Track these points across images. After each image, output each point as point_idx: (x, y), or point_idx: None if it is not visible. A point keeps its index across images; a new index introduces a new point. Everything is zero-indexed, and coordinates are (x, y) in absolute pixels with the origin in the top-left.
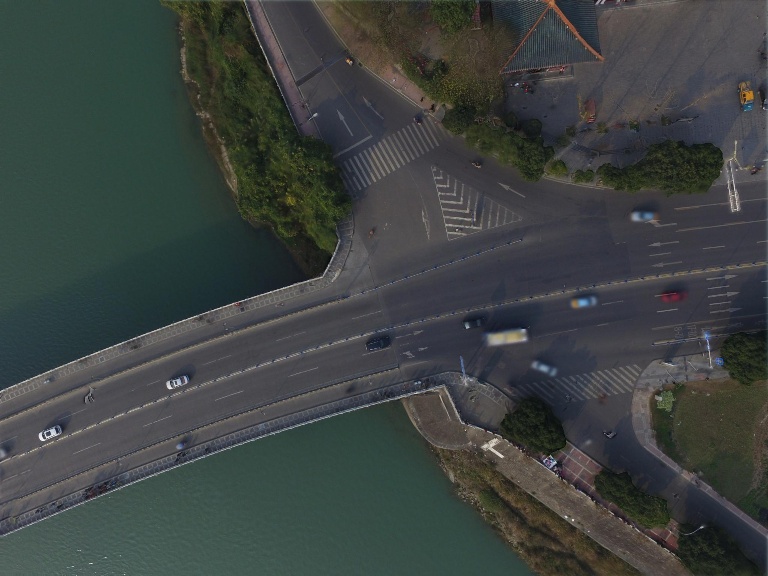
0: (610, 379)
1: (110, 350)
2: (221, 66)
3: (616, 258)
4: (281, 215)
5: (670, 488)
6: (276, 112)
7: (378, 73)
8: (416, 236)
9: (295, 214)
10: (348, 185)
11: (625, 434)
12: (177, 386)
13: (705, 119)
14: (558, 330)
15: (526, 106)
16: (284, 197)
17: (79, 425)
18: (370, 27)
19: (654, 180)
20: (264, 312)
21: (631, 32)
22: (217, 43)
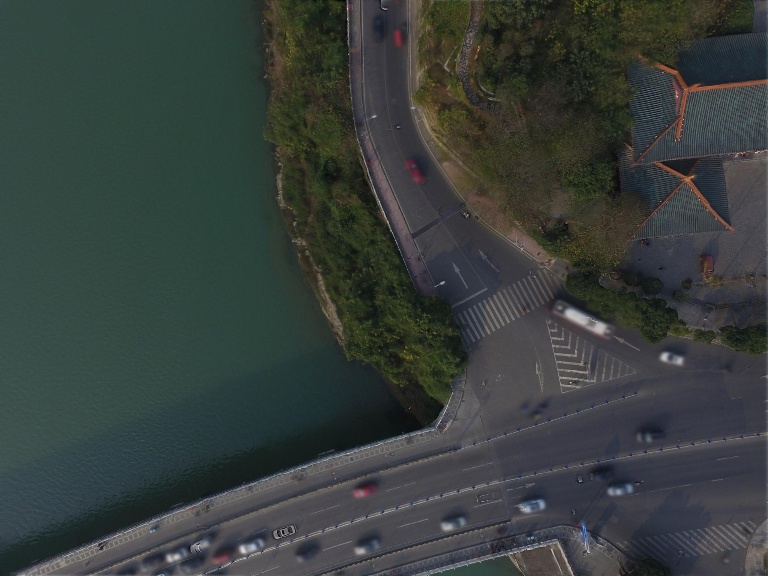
0: (724, 535)
1: (216, 498)
2: (323, 200)
3: (731, 413)
4: (394, 367)
5: None
6: (395, 270)
7: (495, 226)
8: (529, 388)
9: (407, 365)
10: (462, 337)
11: None
12: (284, 536)
13: None
14: (672, 485)
15: (641, 257)
16: (397, 348)
17: (184, 574)
18: (495, 190)
19: None
20: (373, 462)
21: (748, 185)
22: (322, 180)
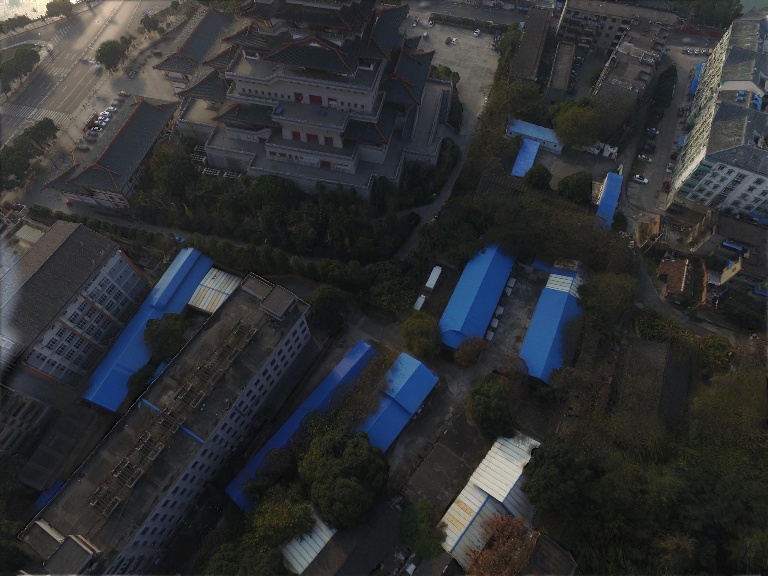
0: None
1: None
2: None
3: None
4: None
5: (5, 44)
6: None
7: None
8: None
9: None
10: None
11: (36, 37)
12: None
13: None
14: None
15: None
16: None
17: None
18: None
19: None
20: None
21: None
22: None
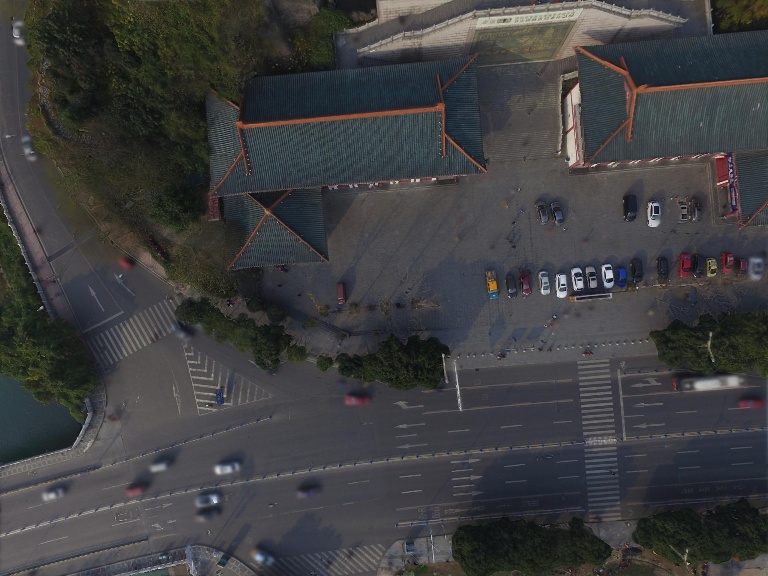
0: (355, 557)
1: None
2: None
3: (363, 438)
4: (31, 387)
5: None
6: (19, 292)
7: (129, 251)
8: (167, 410)
9: None
10: (100, 359)
11: None
12: None
13: (454, 304)
14: (304, 508)
15: (281, 284)
16: None
17: None
18: None
19: (380, 377)
20: (17, 479)
21: (385, 215)
22: None
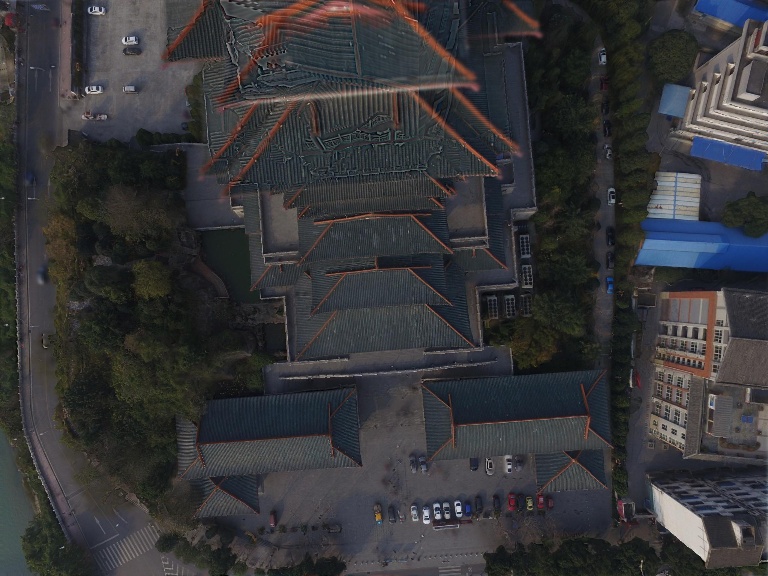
0: None
1: None
2: None
3: None
4: None
5: None
6: (46, 527)
7: None
8: None
9: None
10: (102, 567)
11: None
12: None
13: (352, 526)
14: None
15: None
16: None
17: None
18: None
19: None
20: None
21: None
22: None
